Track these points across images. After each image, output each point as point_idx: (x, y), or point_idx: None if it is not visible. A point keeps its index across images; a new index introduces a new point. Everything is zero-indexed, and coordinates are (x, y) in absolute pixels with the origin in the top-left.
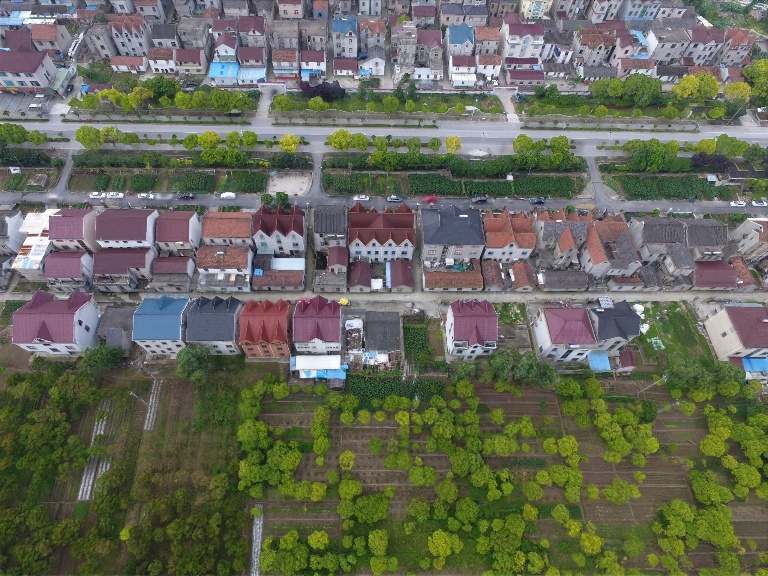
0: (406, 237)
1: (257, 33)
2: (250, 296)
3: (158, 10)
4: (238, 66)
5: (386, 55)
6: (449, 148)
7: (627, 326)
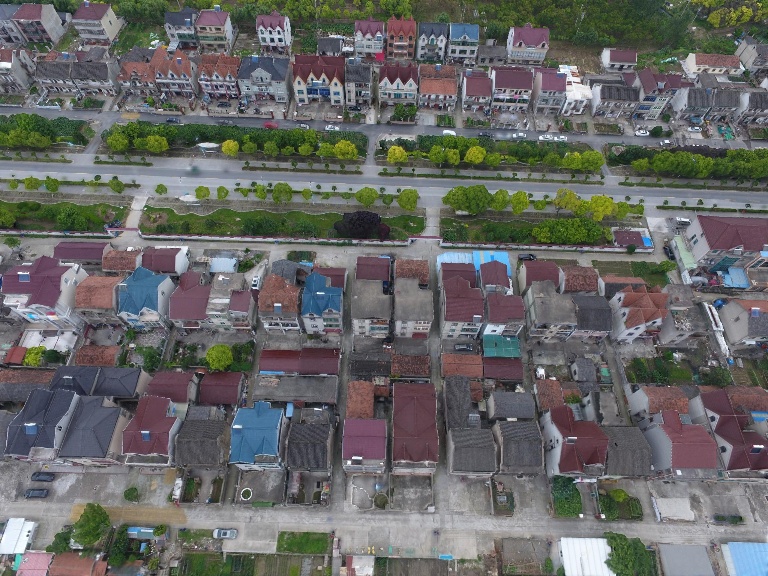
0: None
1: None
2: None
3: None
4: None
5: None
6: None
7: None
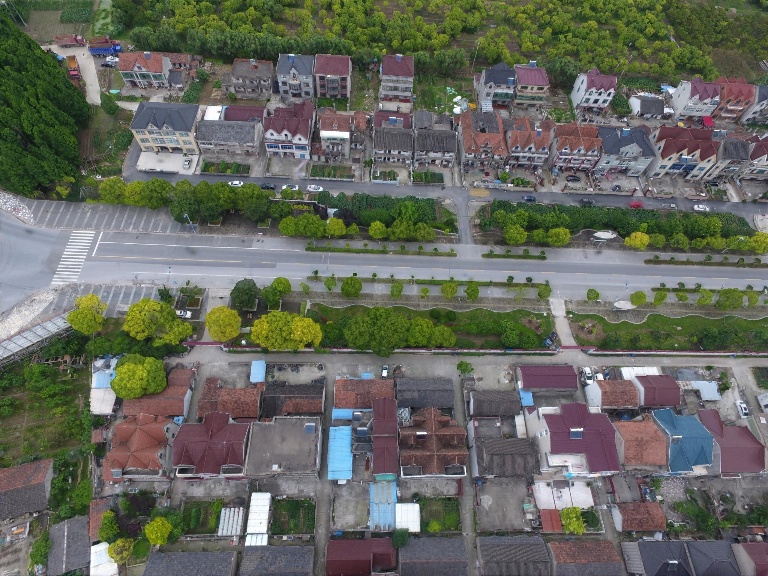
0: None
1: None
2: None
3: None
4: None
5: None
6: None
7: None
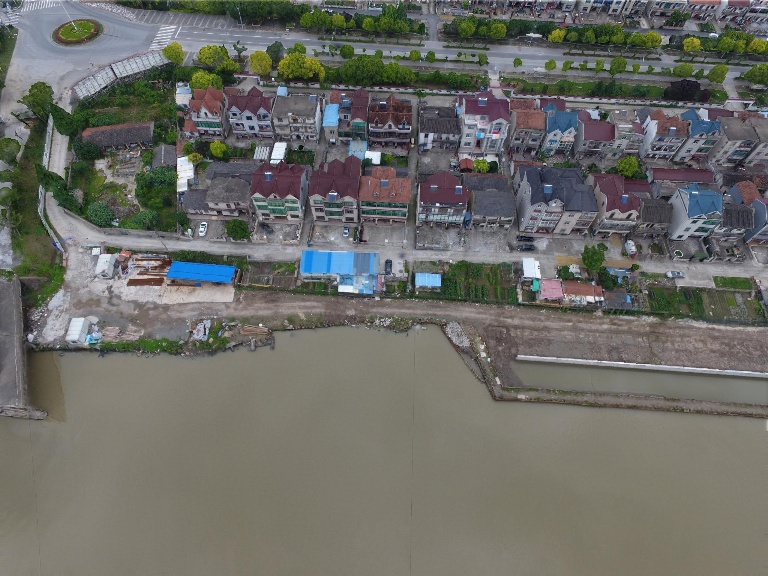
0: None
1: None
2: None
3: None
4: None
5: None
6: None
7: None
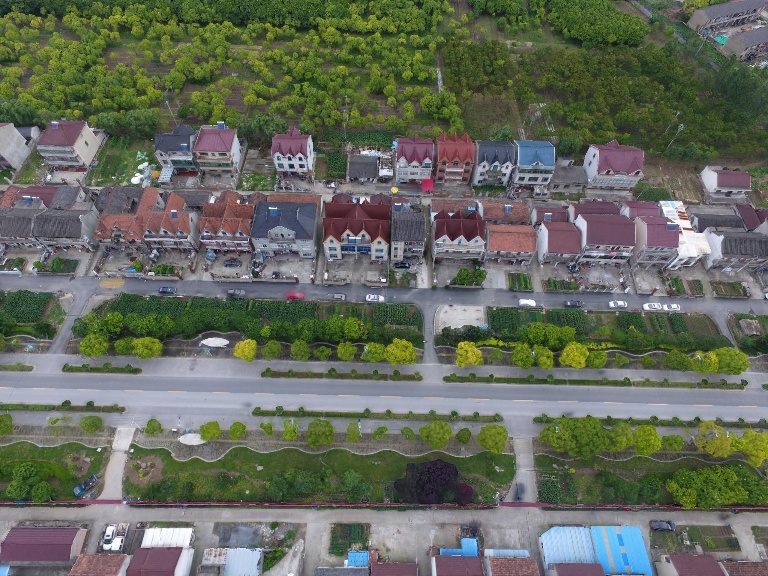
0: None
1: None
2: None
3: None
4: None
5: None
6: None
7: None
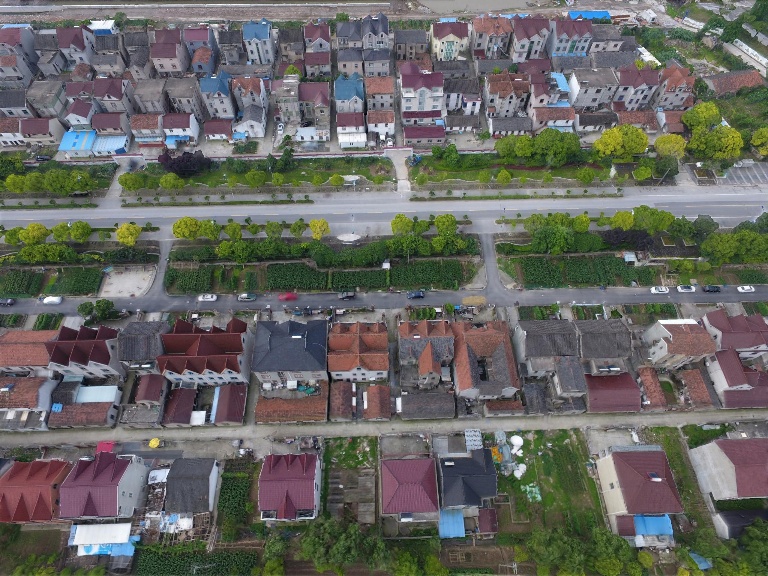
0: (224, 366)
1: (113, 98)
2: (48, 436)
3: (19, 70)
4: (95, 135)
5: (271, 112)
6: (314, 233)
7: (480, 486)
